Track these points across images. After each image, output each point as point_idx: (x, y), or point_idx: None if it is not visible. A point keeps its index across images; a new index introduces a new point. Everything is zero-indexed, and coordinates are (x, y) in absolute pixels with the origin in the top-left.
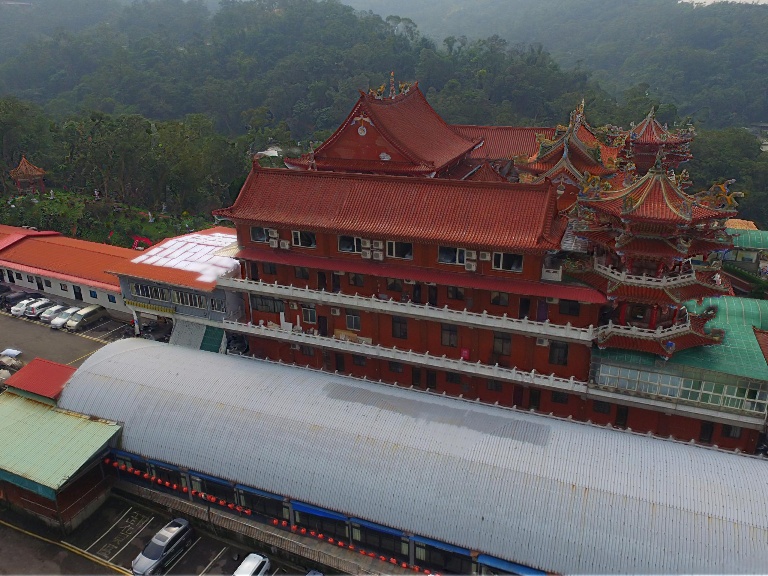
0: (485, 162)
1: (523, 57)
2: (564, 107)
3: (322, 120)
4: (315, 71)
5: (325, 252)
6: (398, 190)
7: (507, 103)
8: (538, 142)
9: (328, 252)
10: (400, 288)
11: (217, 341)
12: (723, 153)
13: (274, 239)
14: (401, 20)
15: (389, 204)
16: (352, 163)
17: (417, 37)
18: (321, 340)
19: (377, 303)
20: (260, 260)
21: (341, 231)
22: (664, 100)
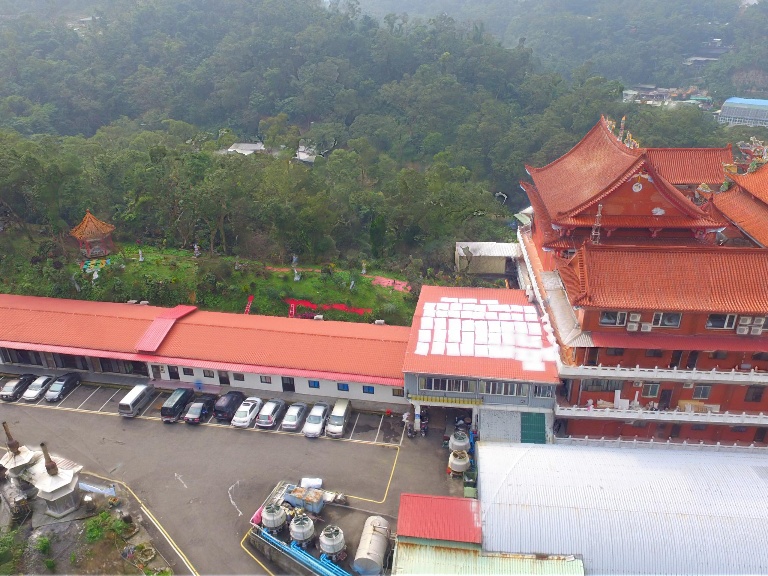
0: (710, 201)
1: (469, 35)
2: (535, 90)
3: (287, 112)
4: (260, 55)
5: (690, 331)
6: (762, 263)
7: (482, 88)
8: (727, 172)
9: (694, 330)
10: (767, 357)
11: (540, 427)
12: (686, 130)
13: (635, 323)
14: None
15: (761, 279)
16: (624, 220)
17: (358, 14)
18: (678, 415)
19: (756, 377)
20: (628, 347)
21: (724, 312)
22: (559, 66)
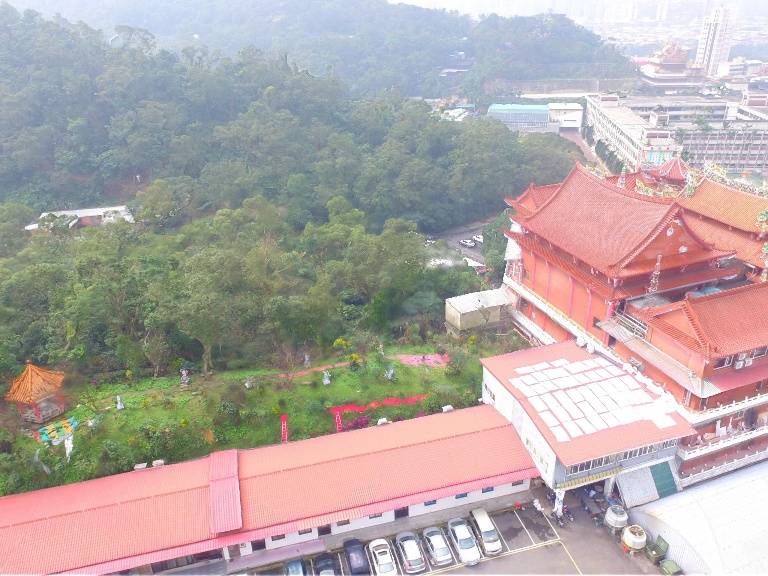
0: None
1: (277, 65)
2: (366, 118)
3: (109, 168)
4: (51, 104)
5: None
6: None
7: (318, 121)
8: None
9: None
10: None
11: (668, 476)
12: (504, 143)
13: (742, 361)
14: (133, 30)
15: None
16: (663, 262)
17: (152, 49)
18: (767, 429)
19: None
20: None
21: None
22: None
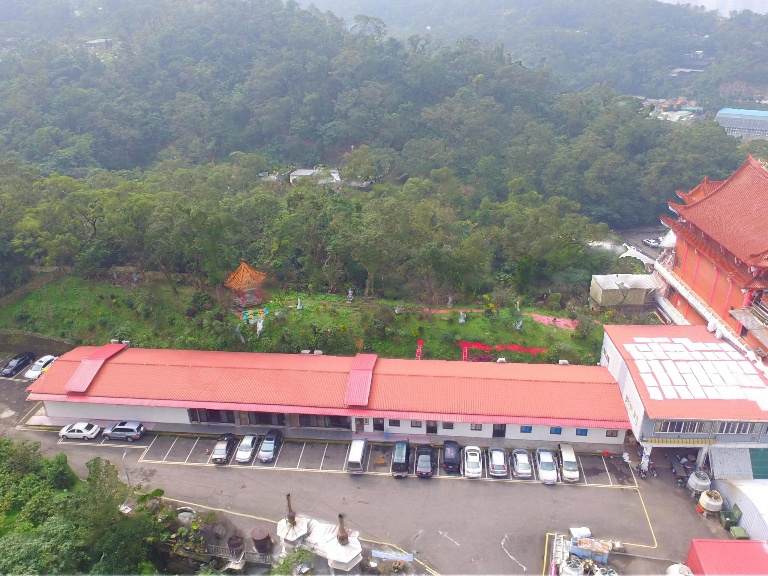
0: None
1: (492, 56)
2: (569, 110)
3: (330, 137)
4: (295, 80)
5: None
6: None
7: (520, 109)
8: None
9: None
10: None
11: None
12: (716, 146)
13: None
14: (369, 19)
15: None
16: None
17: (383, 36)
18: None
19: None
20: None
21: None
22: None
